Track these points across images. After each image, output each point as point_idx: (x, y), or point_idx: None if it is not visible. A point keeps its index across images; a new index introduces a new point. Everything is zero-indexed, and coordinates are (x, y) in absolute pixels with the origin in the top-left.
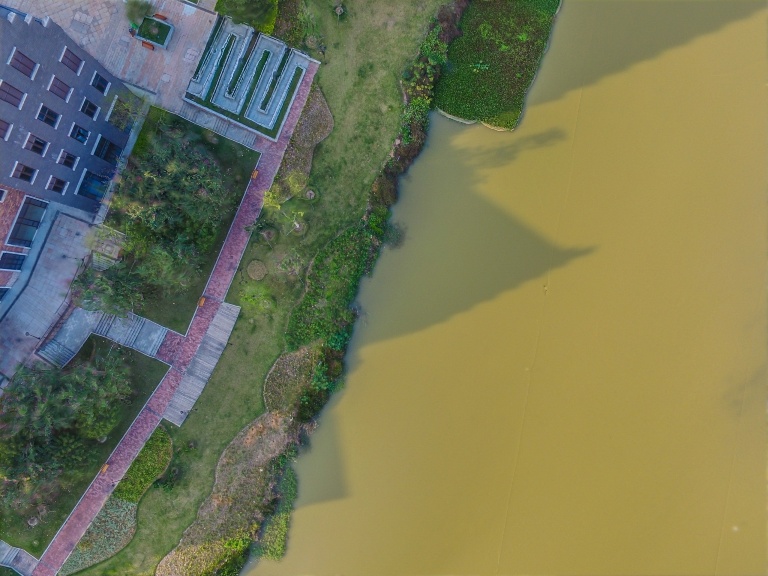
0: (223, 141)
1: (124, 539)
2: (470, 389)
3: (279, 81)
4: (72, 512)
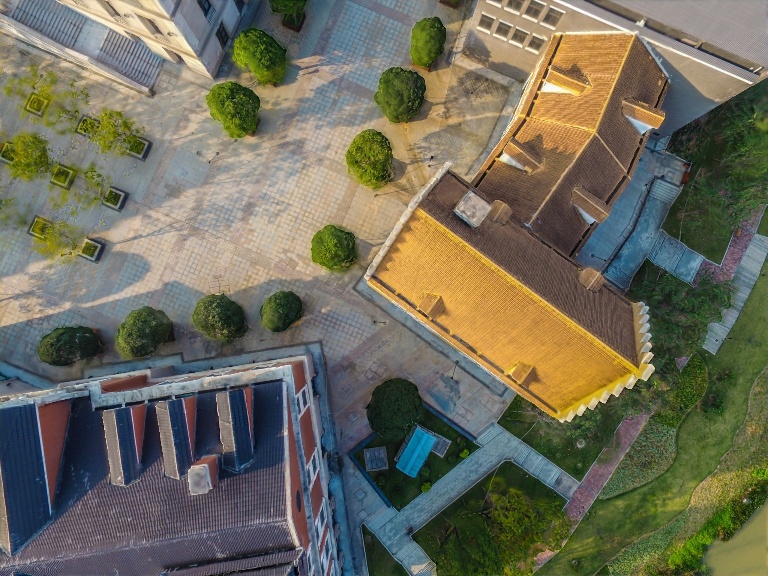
0: None
1: (665, 464)
2: None
3: None
4: None
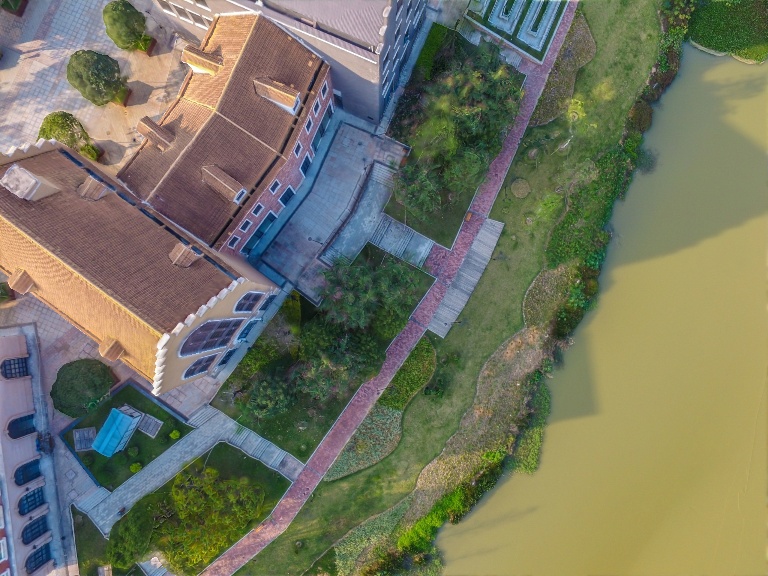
0: None
1: (390, 446)
2: (720, 312)
3: (549, 5)
4: (338, 418)
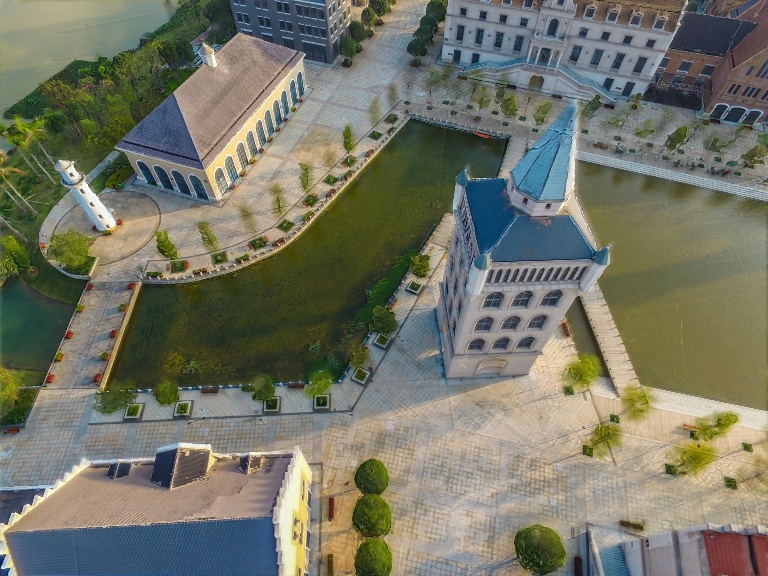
0: None
1: None
2: (132, 3)
3: None
4: None
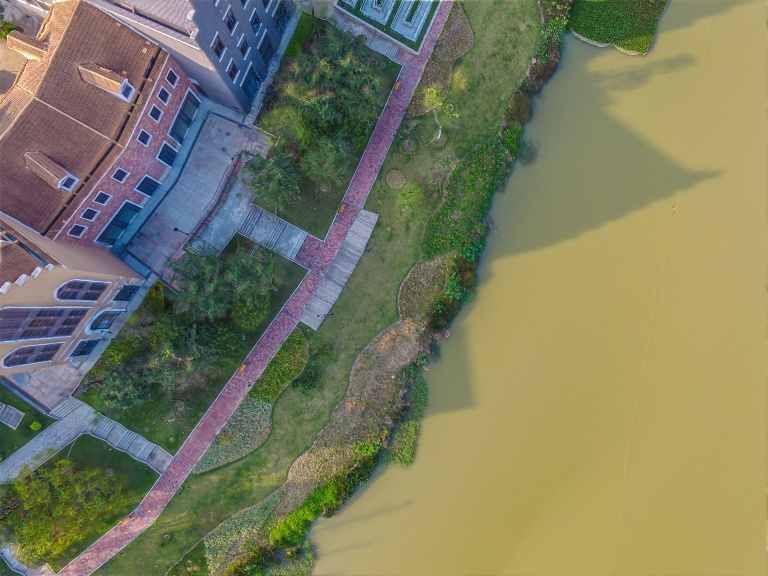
0: (368, 51)
1: (259, 438)
2: (599, 305)
3: None
4: (208, 410)
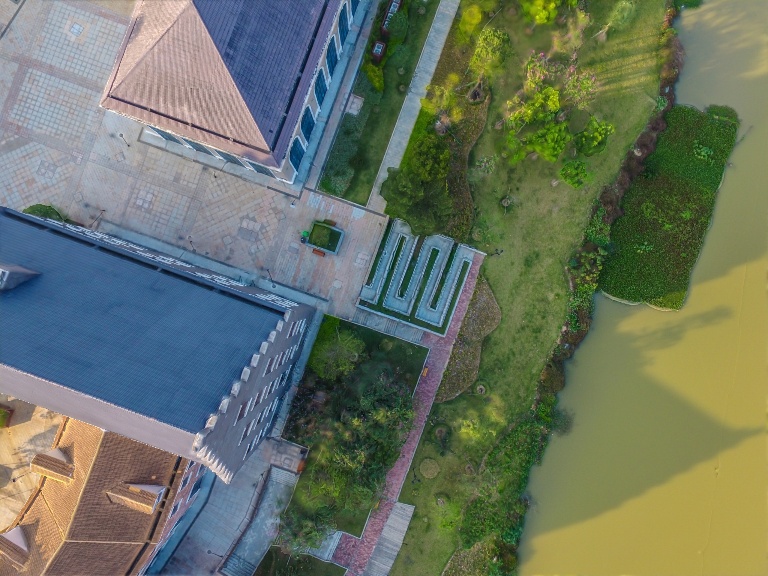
0: (393, 341)
1: None
2: None
3: (448, 277)
4: None
